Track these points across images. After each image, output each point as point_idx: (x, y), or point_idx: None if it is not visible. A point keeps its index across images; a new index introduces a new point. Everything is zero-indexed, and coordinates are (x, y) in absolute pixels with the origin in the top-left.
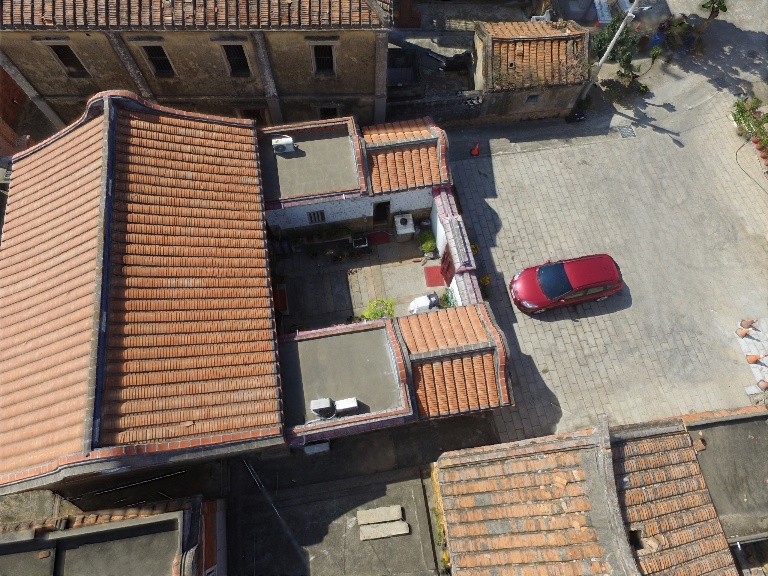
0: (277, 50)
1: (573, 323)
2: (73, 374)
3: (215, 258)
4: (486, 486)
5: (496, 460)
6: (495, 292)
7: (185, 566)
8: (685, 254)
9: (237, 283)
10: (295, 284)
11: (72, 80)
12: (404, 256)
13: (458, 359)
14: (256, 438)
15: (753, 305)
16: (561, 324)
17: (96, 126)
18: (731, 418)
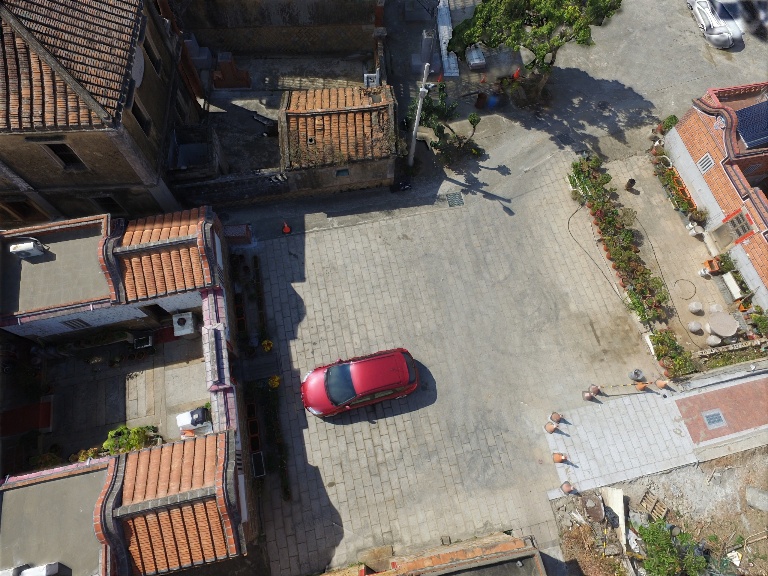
0: (4, 149)
1: (369, 425)
2: None
3: None
4: None
5: None
6: (288, 393)
7: None
8: (501, 338)
9: None
10: (65, 394)
11: None
12: (192, 355)
13: (176, 509)
14: None
15: (567, 394)
16: (356, 427)
17: None
18: (473, 565)
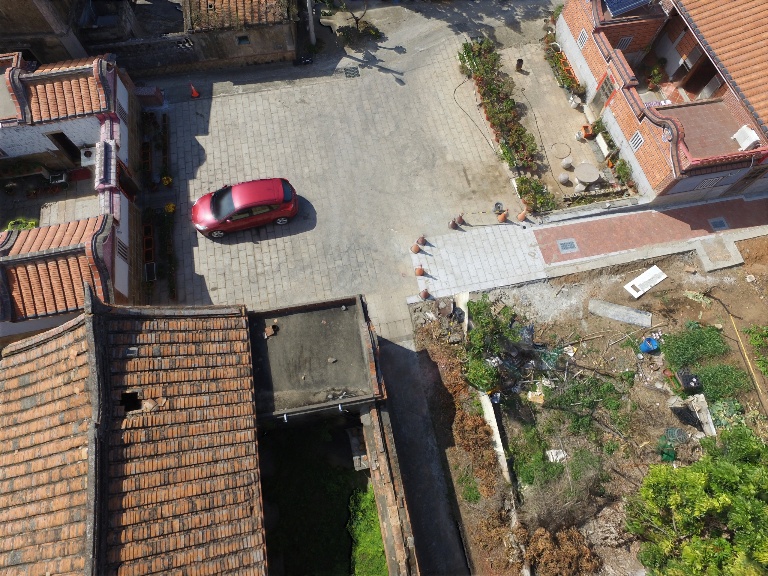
0: None
1: (253, 245)
2: None
3: None
4: (29, 367)
5: (41, 343)
6: (183, 220)
7: None
8: (380, 180)
9: None
10: None
11: None
12: None
13: (52, 261)
14: None
15: (434, 224)
16: (241, 246)
17: None
18: (301, 304)
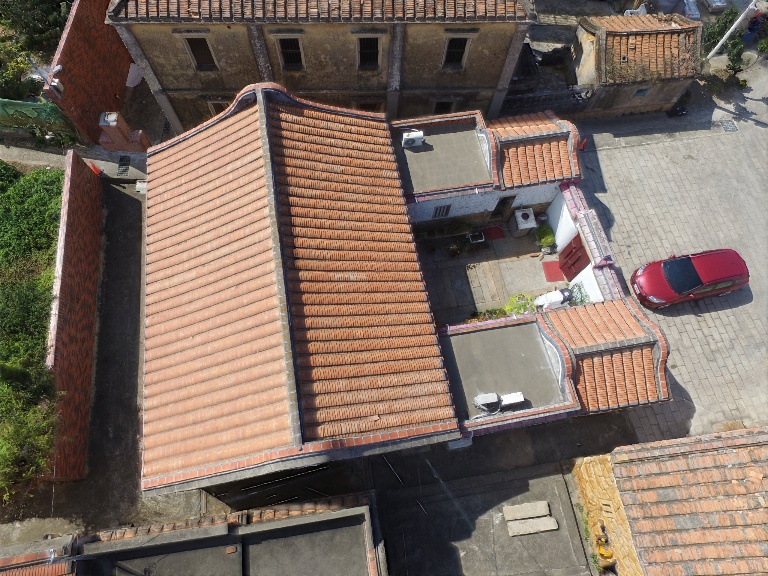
0: (412, 43)
1: (696, 318)
2: (258, 368)
3: (371, 252)
4: (669, 481)
5: (678, 455)
6: None
7: (380, 561)
8: None
9: (395, 277)
10: None
11: (198, 74)
12: (521, 251)
13: (618, 353)
14: (436, 433)
15: None
16: (685, 319)
17: (243, 119)
18: None
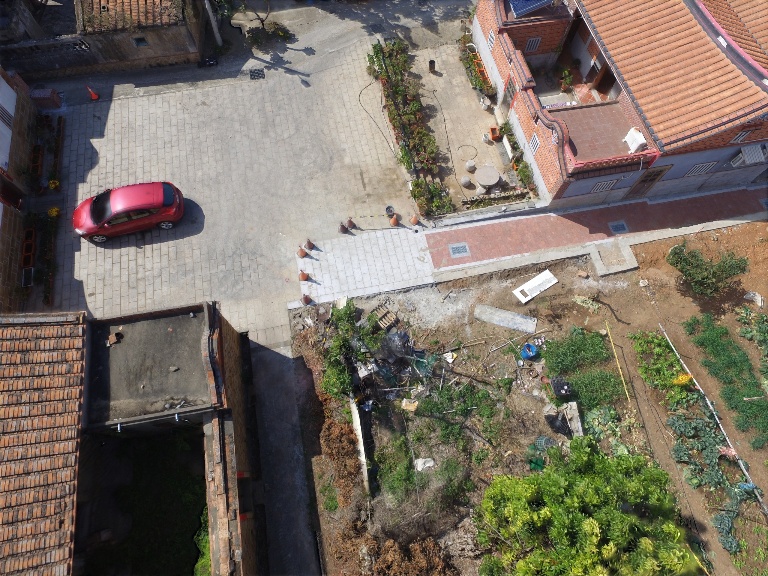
0: None
1: (136, 250)
2: None
3: None
4: None
5: None
6: (68, 224)
7: None
8: (273, 184)
9: None
10: None
11: None
12: None
13: None
14: None
15: (324, 228)
16: (124, 251)
17: None
18: (146, 311)
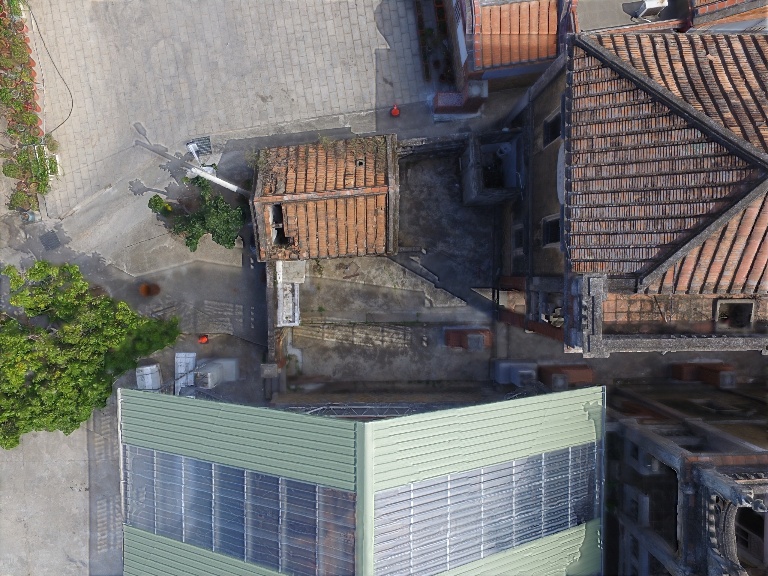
0: None
1: None
2: None
3: None
4: None
5: None
6: None
7: None
8: None
9: None
10: None
11: None
12: None
13: None
14: None
15: None
16: None
17: None
18: None
